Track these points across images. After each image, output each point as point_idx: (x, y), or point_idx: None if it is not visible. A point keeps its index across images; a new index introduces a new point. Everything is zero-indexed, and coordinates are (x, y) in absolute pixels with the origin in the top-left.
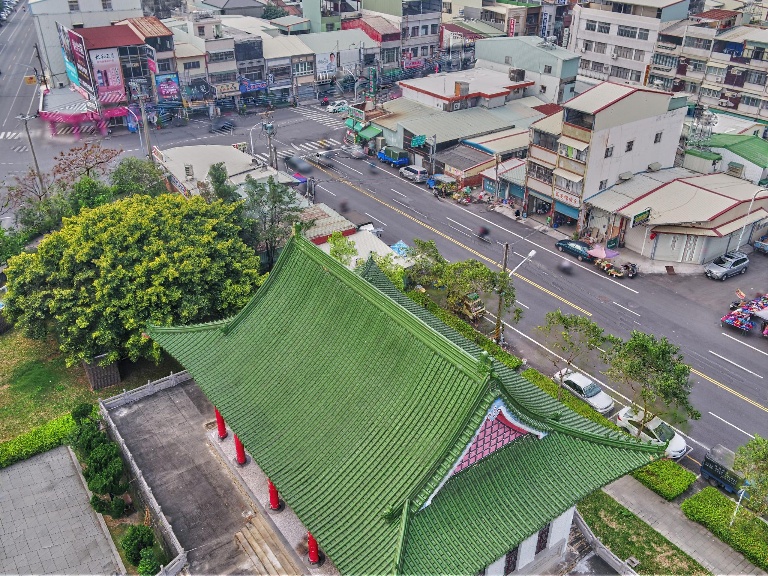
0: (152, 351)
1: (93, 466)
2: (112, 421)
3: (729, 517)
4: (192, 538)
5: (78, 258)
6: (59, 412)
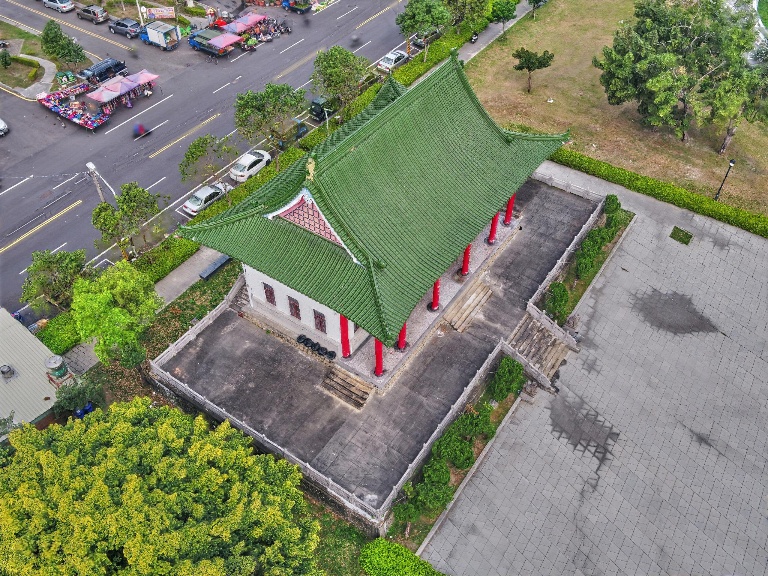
0: None
1: None
2: None
3: (322, 136)
4: (479, 356)
5: (220, 572)
6: None
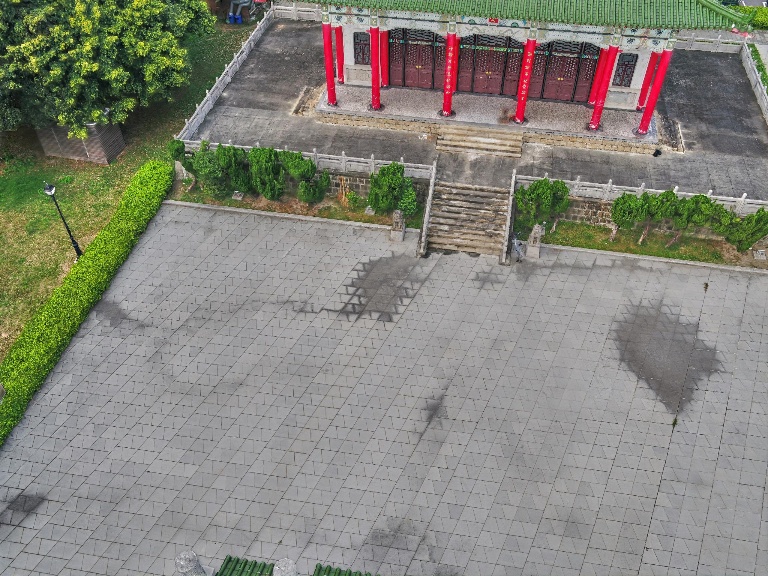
0: (170, 79)
1: (271, 165)
2: (213, 145)
3: None
4: None
5: None
6: (105, 193)
